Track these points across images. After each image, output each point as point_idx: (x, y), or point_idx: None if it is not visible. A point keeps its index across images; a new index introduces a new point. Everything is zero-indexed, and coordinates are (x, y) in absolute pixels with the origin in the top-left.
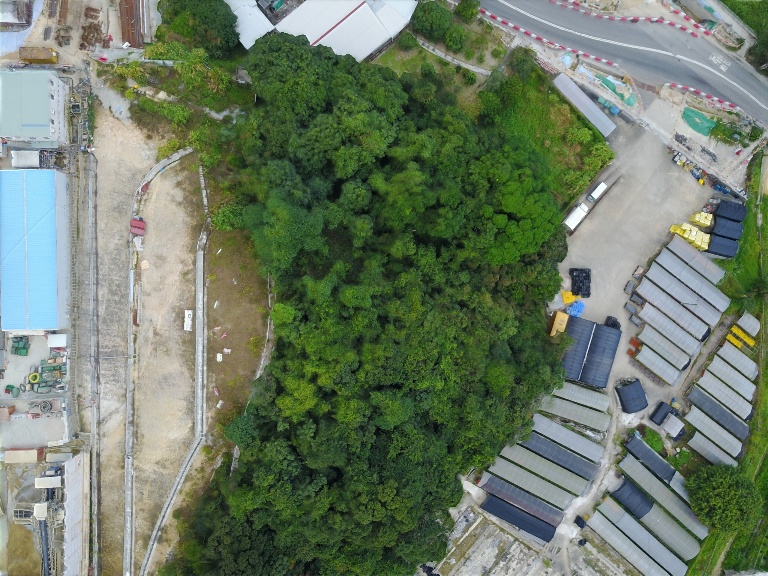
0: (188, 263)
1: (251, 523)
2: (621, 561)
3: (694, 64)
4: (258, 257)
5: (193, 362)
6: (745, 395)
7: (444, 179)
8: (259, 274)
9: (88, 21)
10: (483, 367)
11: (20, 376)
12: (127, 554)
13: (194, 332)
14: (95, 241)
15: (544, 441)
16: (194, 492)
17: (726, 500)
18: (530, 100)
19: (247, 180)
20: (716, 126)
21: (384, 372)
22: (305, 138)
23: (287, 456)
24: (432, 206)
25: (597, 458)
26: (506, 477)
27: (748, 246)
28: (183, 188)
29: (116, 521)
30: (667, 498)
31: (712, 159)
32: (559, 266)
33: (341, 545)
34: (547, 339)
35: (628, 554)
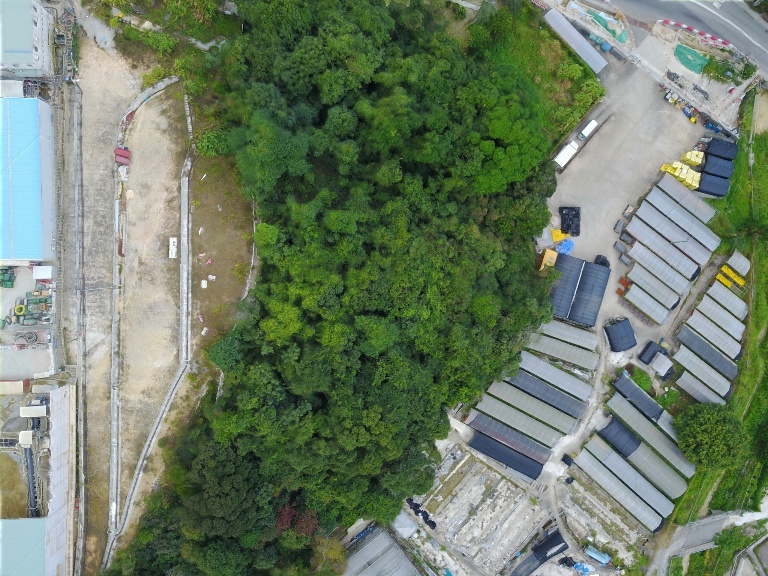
0: (173, 190)
1: (236, 449)
2: (608, 499)
3: (687, 1)
4: None
5: (178, 289)
6: (734, 335)
7: (431, 105)
8: (244, 201)
9: None
10: (470, 297)
11: (6, 308)
12: (113, 484)
13: (179, 259)
14: (80, 173)
15: (532, 379)
16: (179, 421)
17: (713, 435)
18: (521, 36)
19: (231, 104)
20: (709, 63)
21: (369, 296)
22: (290, 61)
23: (271, 380)
24: (418, 132)
25: (585, 396)
26: (494, 414)
27: (739, 186)
28: (168, 116)
29: (102, 452)
30: (655, 436)
31: (704, 97)
32: (548, 201)
33: (327, 476)
34: (535, 274)
35: (615, 492)
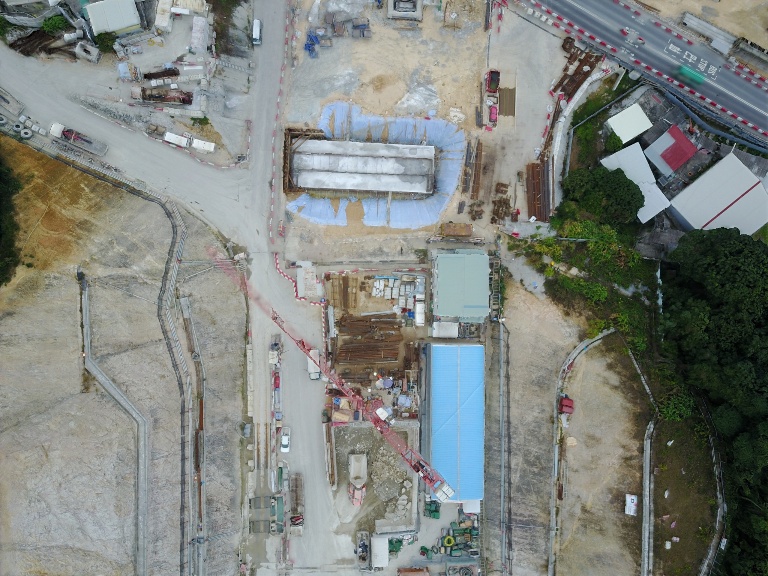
0: (631, 449)
1: None
2: None
3: None
4: (703, 447)
5: (638, 547)
6: None
7: None
8: (705, 464)
9: (498, 195)
10: None
11: (431, 538)
12: None
13: (640, 518)
14: (507, 410)
15: None
16: None
17: None
18: None
19: (705, 377)
20: None
21: None
22: None
23: None
24: None
25: None
26: None
27: None
28: (617, 372)
29: None
30: None
31: None
32: None
33: None
34: None
35: None
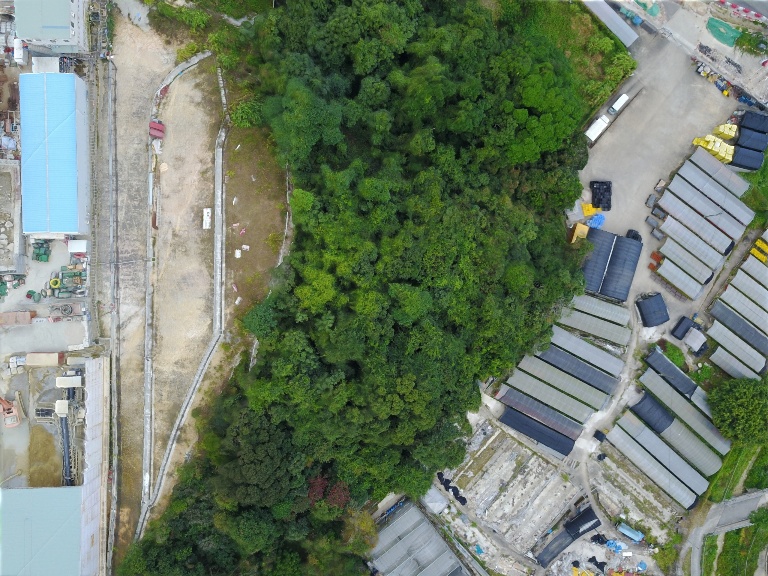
0: (207, 161)
1: (269, 417)
2: (641, 476)
3: None
4: (276, 154)
5: (212, 259)
6: None
7: (464, 73)
8: (277, 171)
9: None
10: (502, 267)
11: (41, 282)
12: (147, 455)
13: (213, 229)
14: (114, 148)
15: (563, 354)
16: (213, 391)
17: (749, 410)
18: (550, 10)
19: (266, 74)
20: (741, 36)
21: (403, 264)
22: (324, 30)
23: (305, 348)
24: (451, 100)
25: (617, 372)
26: (524, 390)
27: None
28: (202, 89)
29: (136, 423)
30: (688, 412)
31: (737, 70)
32: (579, 174)
33: (359, 448)
34: (567, 246)
35: (648, 468)
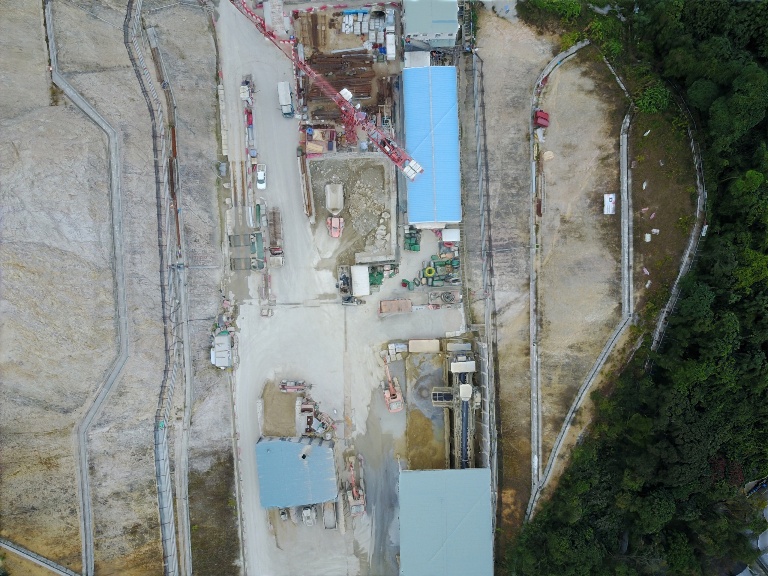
0: (608, 148)
1: (689, 398)
2: None
3: None
4: (681, 139)
5: (618, 244)
6: None
7: None
8: (684, 155)
9: None
10: None
11: (413, 271)
12: (534, 438)
13: (619, 214)
14: (483, 138)
15: None
16: (612, 374)
17: None
18: None
19: (680, 60)
20: None
21: None
22: (745, 14)
23: None
24: None
25: None
26: None
27: None
28: (592, 77)
29: (520, 407)
30: None
31: None
32: None
33: None
34: None
35: None
